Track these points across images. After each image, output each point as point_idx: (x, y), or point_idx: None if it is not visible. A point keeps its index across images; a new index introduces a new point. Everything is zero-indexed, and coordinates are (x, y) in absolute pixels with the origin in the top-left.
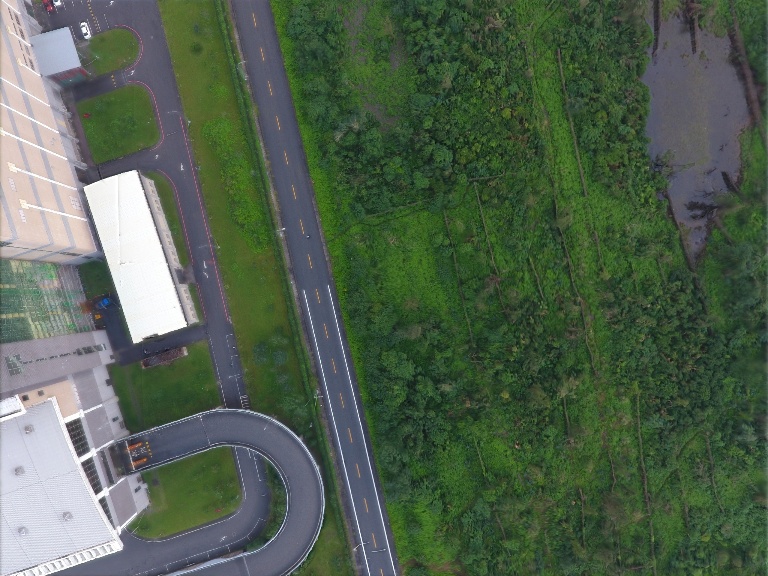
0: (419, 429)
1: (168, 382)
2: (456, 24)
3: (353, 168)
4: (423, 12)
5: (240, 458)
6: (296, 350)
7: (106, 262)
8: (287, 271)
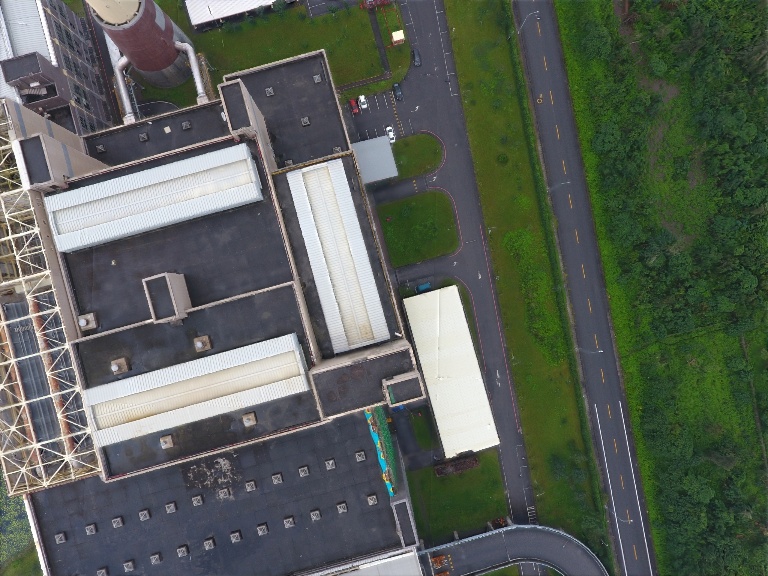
0: (719, 555)
1: (457, 490)
2: (766, 150)
3: (653, 287)
4: (732, 136)
5: (524, 569)
6: (590, 466)
7: (422, 375)
8: (580, 385)
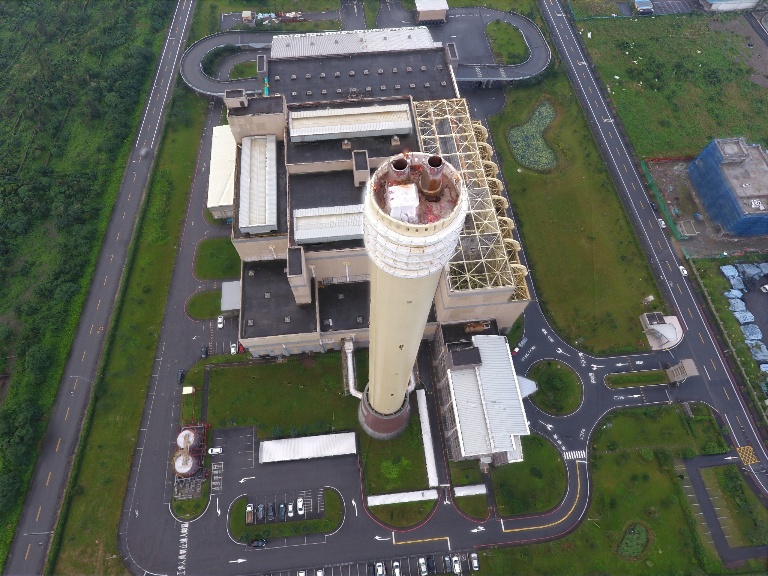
0: (118, 71)
1: None
2: None
3: None
4: None
5: None
6: None
7: None
8: None
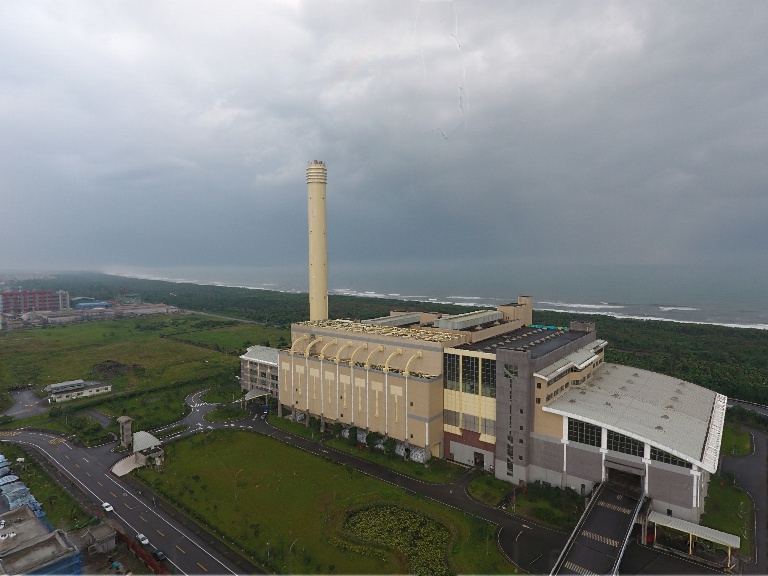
0: None
1: None
2: None
3: None
4: None
5: None
6: None
7: None
8: None
